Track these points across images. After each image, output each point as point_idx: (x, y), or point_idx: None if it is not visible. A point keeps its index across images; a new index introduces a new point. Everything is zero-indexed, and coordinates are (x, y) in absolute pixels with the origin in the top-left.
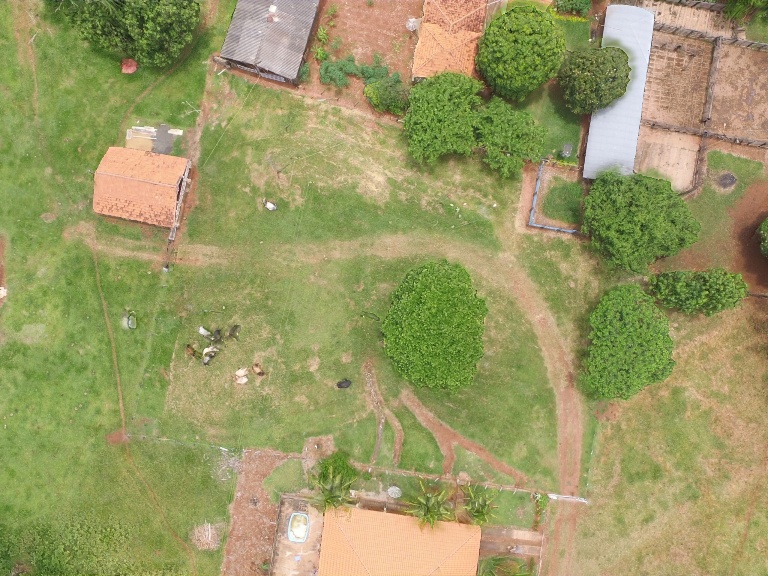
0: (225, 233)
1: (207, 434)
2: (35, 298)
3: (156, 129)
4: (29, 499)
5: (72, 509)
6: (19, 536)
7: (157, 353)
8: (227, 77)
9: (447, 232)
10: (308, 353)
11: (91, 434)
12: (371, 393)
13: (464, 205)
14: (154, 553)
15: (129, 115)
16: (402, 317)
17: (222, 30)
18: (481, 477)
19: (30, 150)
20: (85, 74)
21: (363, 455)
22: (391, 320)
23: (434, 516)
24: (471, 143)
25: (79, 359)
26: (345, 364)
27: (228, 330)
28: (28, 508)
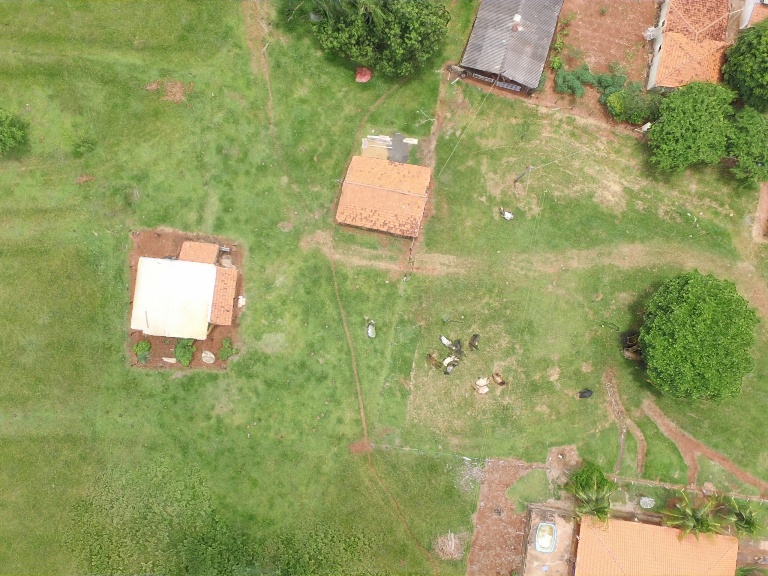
0: (462, 242)
1: (450, 444)
2: (274, 307)
3: (391, 138)
4: (272, 508)
5: (316, 518)
6: (263, 545)
7: (397, 362)
8: (461, 86)
9: (685, 242)
10: (548, 363)
11: (334, 443)
12: (612, 403)
13: (700, 214)
14: (398, 562)
15: (364, 124)
16: (673, 328)
17: (454, 39)
18: (726, 487)
19: (266, 159)
20: (319, 83)
21: (607, 465)
22: (658, 331)
23: (702, 528)
24: (721, 153)
25: (319, 368)
26: (585, 374)
27: (467, 339)
28: (271, 517)
